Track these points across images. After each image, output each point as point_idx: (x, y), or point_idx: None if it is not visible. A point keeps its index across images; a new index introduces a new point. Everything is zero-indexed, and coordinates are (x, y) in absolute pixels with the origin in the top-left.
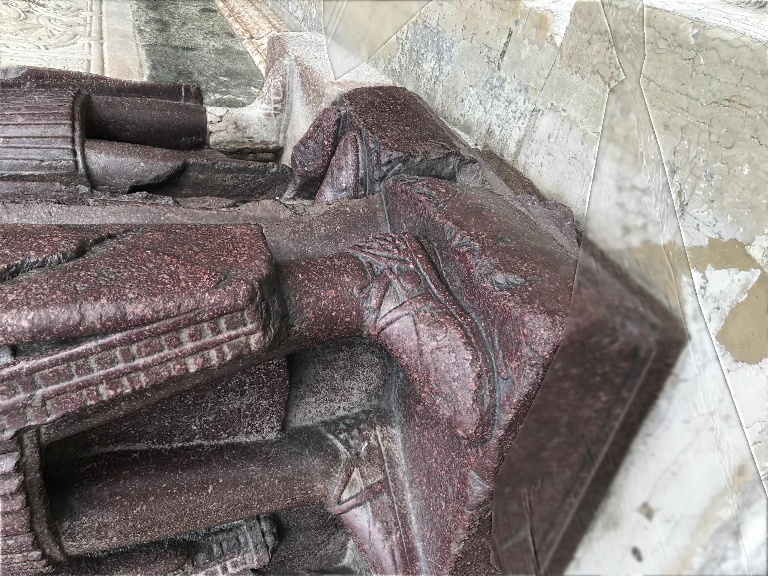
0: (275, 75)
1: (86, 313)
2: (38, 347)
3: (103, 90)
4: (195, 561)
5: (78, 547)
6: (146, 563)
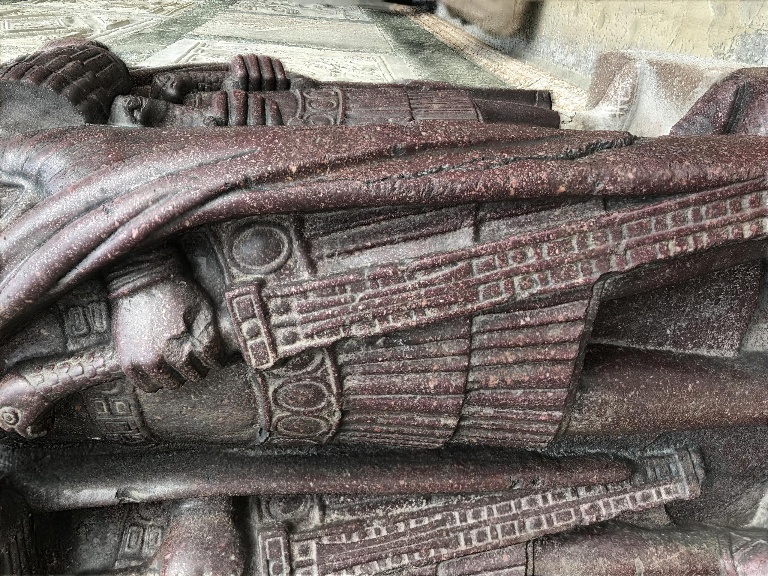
0: (624, 78)
1: (675, 172)
2: (623, 204)
3: (477, 94)
4: (632, 480)
5: (579, 422)
6: (600, 468)
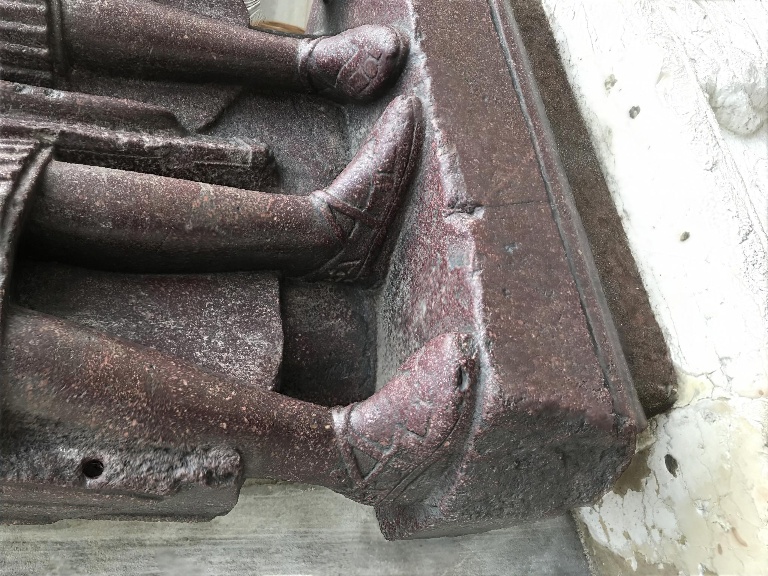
0: None
1: None
2: None
3: None
4: None
5: None
6: None
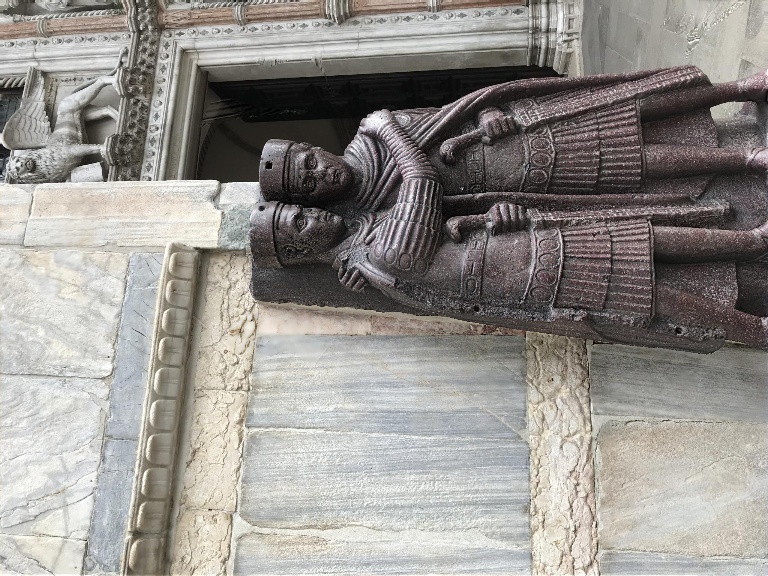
0: None
1: None
2: None
3: None
4: None
5: (650, 156)
6: None
